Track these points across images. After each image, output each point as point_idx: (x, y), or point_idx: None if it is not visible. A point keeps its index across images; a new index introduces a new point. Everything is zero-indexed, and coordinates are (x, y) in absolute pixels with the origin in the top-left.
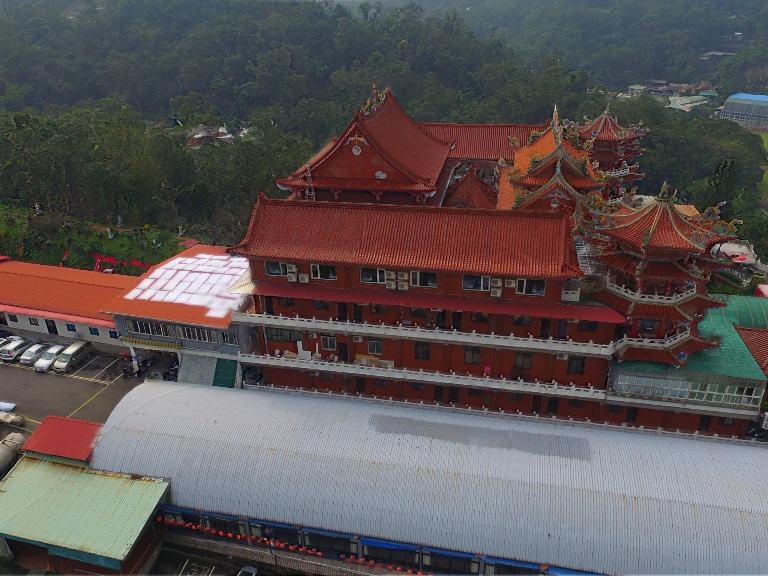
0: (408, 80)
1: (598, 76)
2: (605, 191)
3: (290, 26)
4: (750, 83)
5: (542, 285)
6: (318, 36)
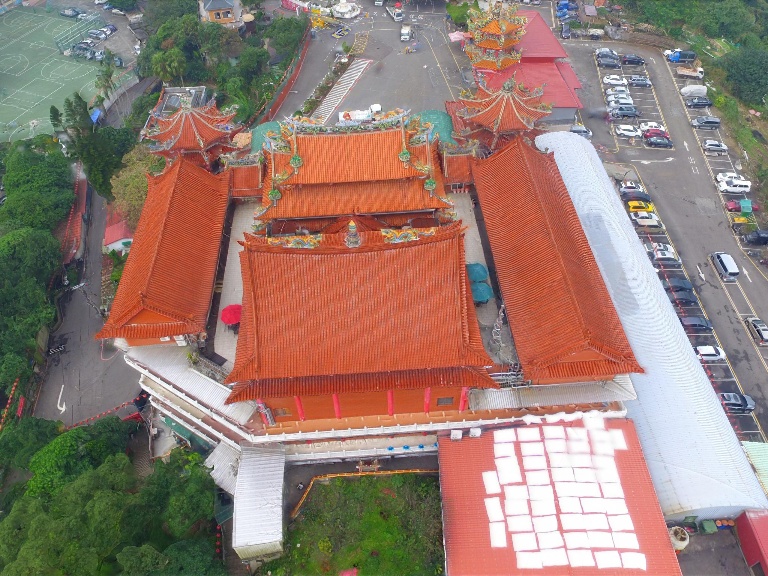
0: None
1: None
2: None
3: None
4: None
5: None
6: None
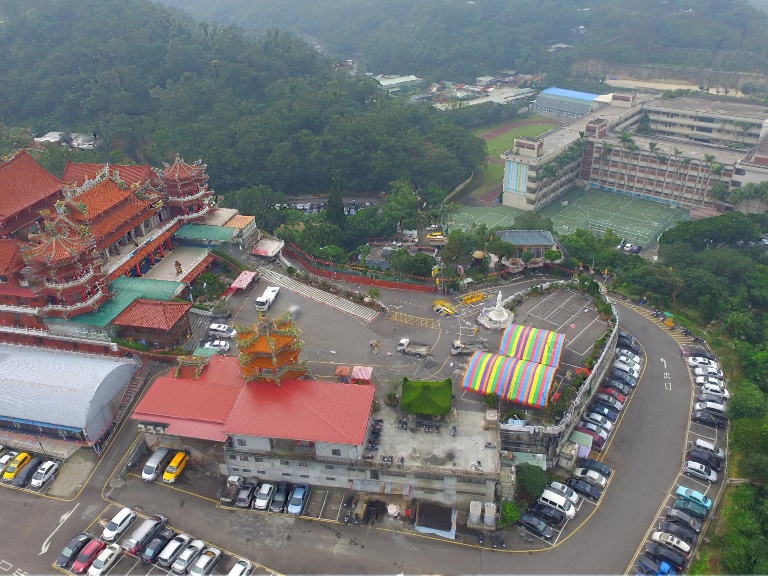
0: (209, 96)
1: (453, 68)
2: (184, 209)
3: (130, 47)
4: (574, 76)
5: (7, 278)
6: (157, 54)
